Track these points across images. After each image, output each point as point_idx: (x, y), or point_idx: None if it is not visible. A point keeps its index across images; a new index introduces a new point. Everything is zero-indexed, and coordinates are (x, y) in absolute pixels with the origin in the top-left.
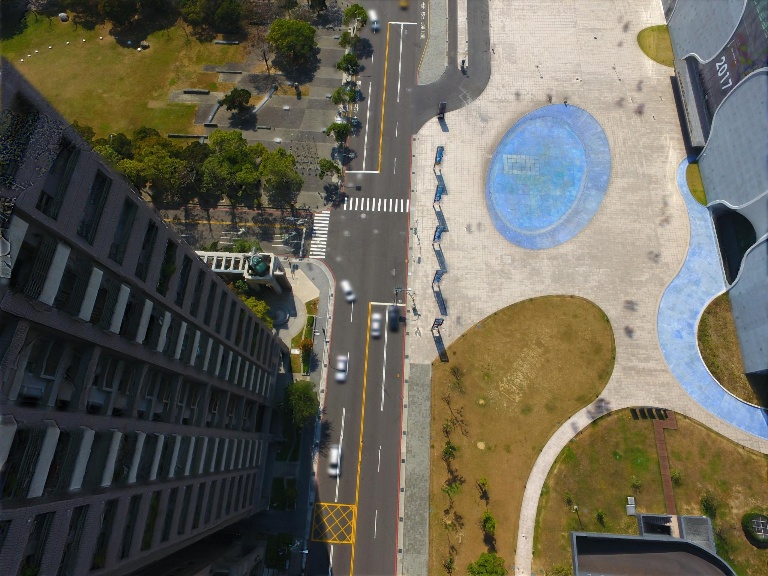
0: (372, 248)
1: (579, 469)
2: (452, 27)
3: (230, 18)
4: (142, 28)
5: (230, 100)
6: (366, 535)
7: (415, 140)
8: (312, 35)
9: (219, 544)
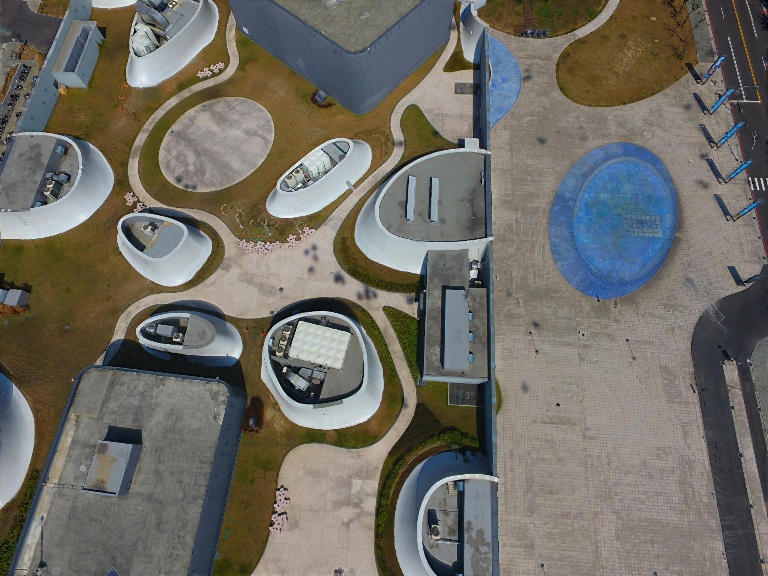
0: None
1: (585, 8)
2: (759, 438)
3: None
4: None
5: None
6: None
7: (763, 257)
8: None
9: None
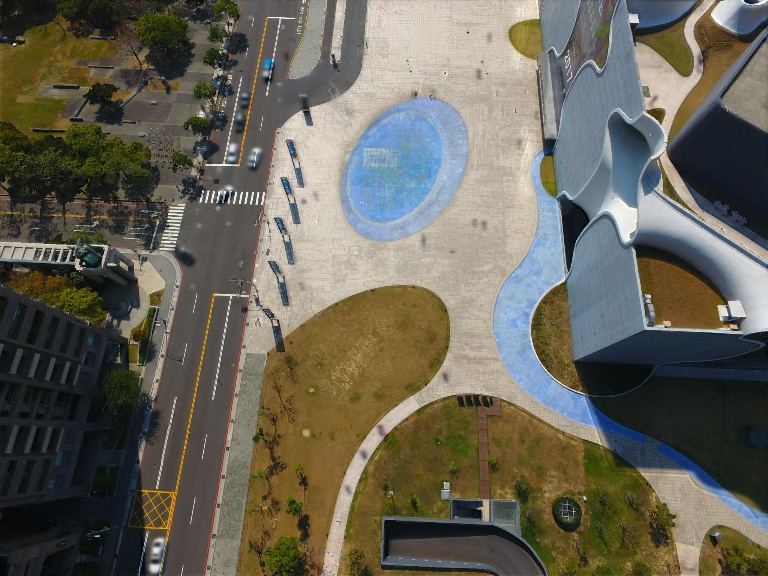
0: (223, 240)
1: (399, 455)
2: (329, 22)
3: (103, 13)
4: (20, 23)
5: (91, 94)
6: (182, 521)
7: (279, 134)
8: (180, 30)
9: (31, 530)
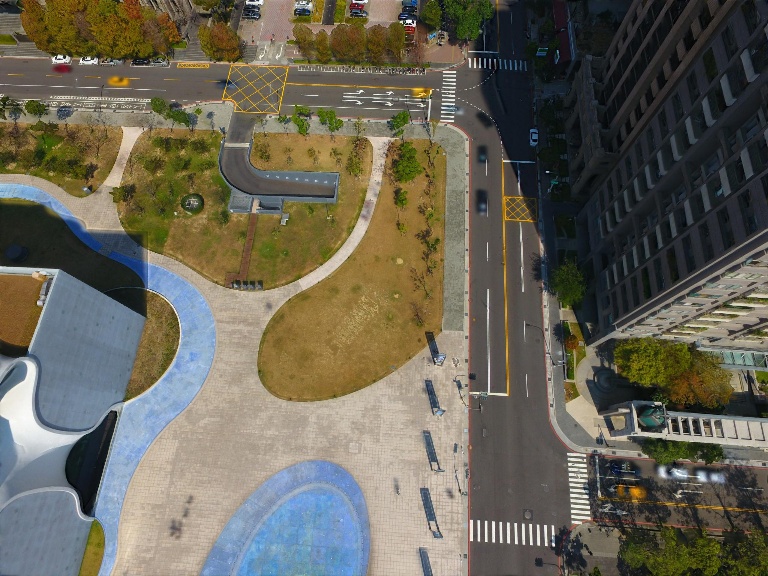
0: (512, 466)
1: (320, 244)
2: None
3: None
4: None
5: None
6: (494, 201)
7: None
8: None
9: None
